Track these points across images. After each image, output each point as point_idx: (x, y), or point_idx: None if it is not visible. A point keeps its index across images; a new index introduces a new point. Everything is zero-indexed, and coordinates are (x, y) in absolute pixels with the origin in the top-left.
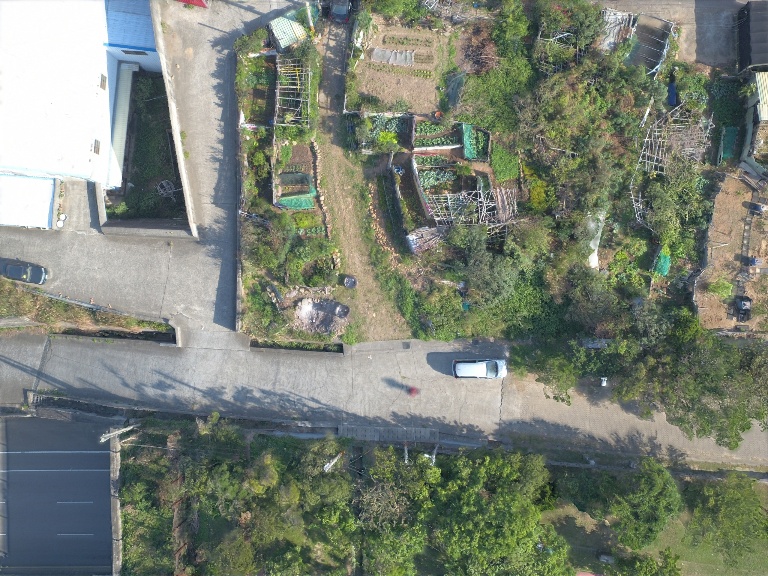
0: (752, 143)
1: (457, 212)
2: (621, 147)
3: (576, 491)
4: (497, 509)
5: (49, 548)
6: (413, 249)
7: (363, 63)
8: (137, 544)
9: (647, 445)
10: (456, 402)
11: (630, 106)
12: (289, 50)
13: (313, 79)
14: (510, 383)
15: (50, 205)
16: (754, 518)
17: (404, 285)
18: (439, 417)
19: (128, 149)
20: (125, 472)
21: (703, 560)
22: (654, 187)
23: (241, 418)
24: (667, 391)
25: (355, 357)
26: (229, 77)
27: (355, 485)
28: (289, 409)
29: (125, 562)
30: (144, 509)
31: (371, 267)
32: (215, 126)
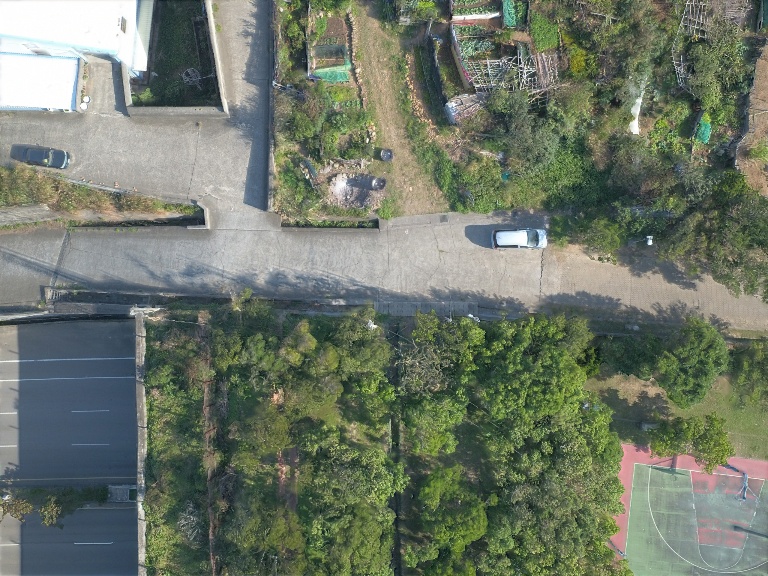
0: None
1: (497, 79)
2: (661, 13)
3: (622, 354)
4: (545, 366)
5: (63, 459)
6: (452, 117)
7: None
8: (163, 431)
9: (689, 315)
10: (495, 275)
11: None
12: None
13: None
14: (550, 254)
15: (74, 86)
16: None
17: (442, 157)
18: (478, 290)
19: (152, 38)
20: (151, 358)
21: (747, 430)
22: (696, 50)
23: (272, 299)
24: (715, 245)
25: (391, 232)
26: None
27: (397, 349)
28: (322, 288)
29: (150, 451)
30: (172, 392)
31: (407, 140)
32: None
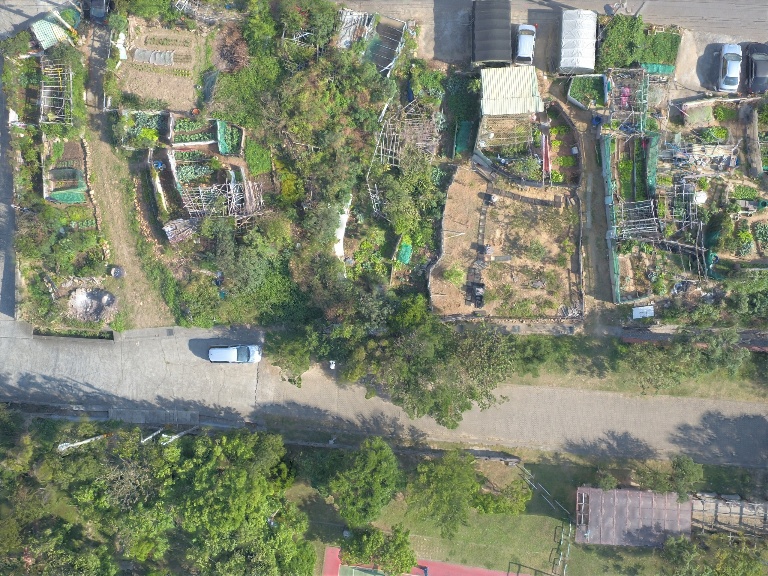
0: (479, 136)
1: (209, 205)
2: (361, 141)
3: (310, 469)
4: (225, 486)
5: None
6: (170, 240)
7: (126, 63)
8: None
9: (391, 426)
10: (215, 386)
11: (367, 102)
12: None
13: (75, 79)
14: (264, 367)
15: None
16: (471, 494)
17: (166, 275)
18: (199, 400)
19: None
20: None
21: None
22: (387, 179)
23: (23, 403)
24: None
25: (124, 344)
26: None
27: (103, 464)
28: (67, 394)
29: None
30: None
31: (138, 258)
32: None
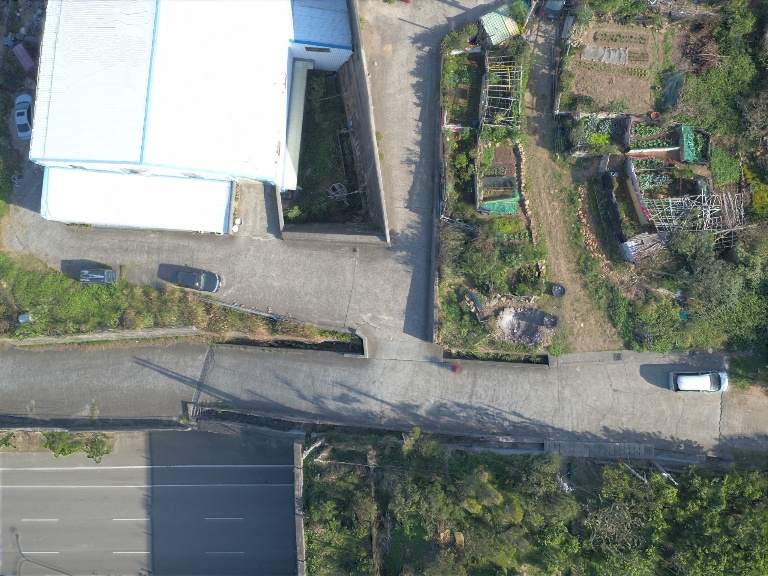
0: None
1: (679, 217)
2: None
3: None
4: (744, 531)
5: (196, 566)
6: (631, 256)
7: (573, 61)
8: (323, 565)
9: None
10: (672, 416)
11: None
12: (498, 47)
13: (524, 77)
14: (730, 396)
15: (226, 209)
16: None
17: (616, 294)
18: (654, 432)
19: None
20: (309, 489)
21: None
22: None
23: (435, 433)
24: None
25: (561, 369)
26: (429, 75)
27: (584, 505)
28: (487, 423)
29: None
30: (334, 529)
31: (579, 275)
32: (412, 127)
